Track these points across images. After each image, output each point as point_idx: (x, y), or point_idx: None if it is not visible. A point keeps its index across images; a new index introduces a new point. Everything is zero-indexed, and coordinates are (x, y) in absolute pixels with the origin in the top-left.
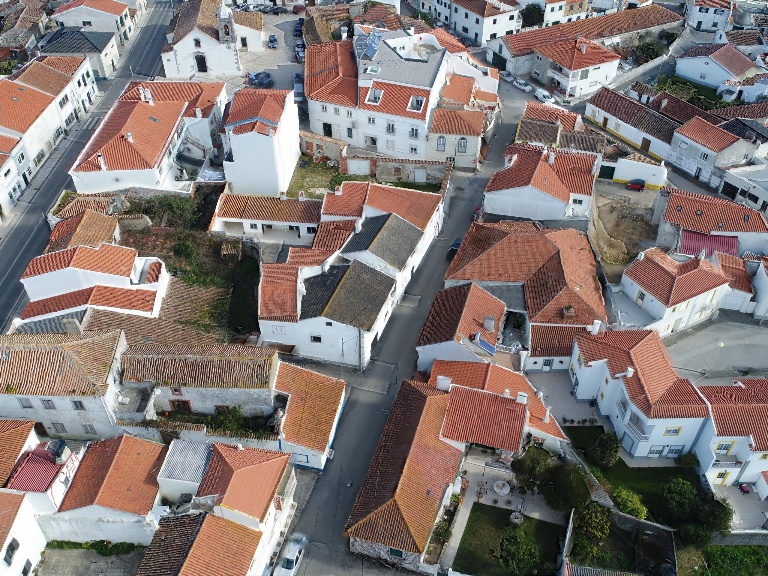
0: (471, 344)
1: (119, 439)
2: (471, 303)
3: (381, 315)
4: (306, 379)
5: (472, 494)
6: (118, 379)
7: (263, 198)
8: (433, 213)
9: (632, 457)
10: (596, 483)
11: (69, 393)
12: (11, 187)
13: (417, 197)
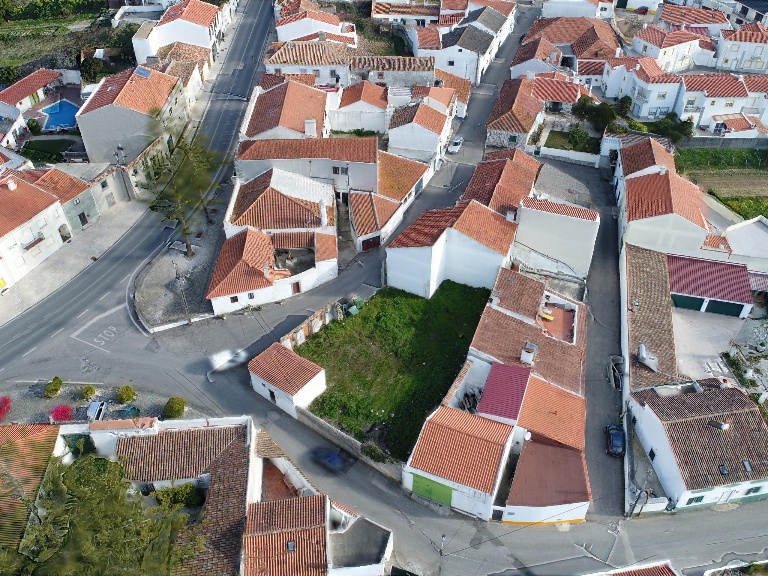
0: (544, 63)
1: (362, 83)
2: (542, 46)
3: (487, 55)
4: (450, 77)
5: (549, 127)
6: (349, 67)
7: (400, 4)
8: (511, 11)
9: (639, 118)
10: (619, 118)
11: (331, 63)
12: (233, 2)
13: (500, 2)
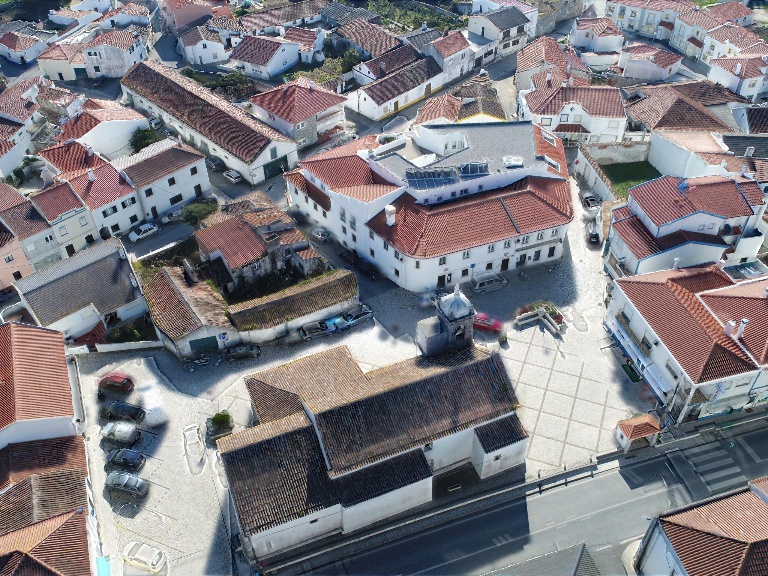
0: None
1: None
2: None
3: None
4: None
5: None
6: None
7: (763, 218)
8: None
9: None
10: None
11: None
12: None
13: (674, 139)
